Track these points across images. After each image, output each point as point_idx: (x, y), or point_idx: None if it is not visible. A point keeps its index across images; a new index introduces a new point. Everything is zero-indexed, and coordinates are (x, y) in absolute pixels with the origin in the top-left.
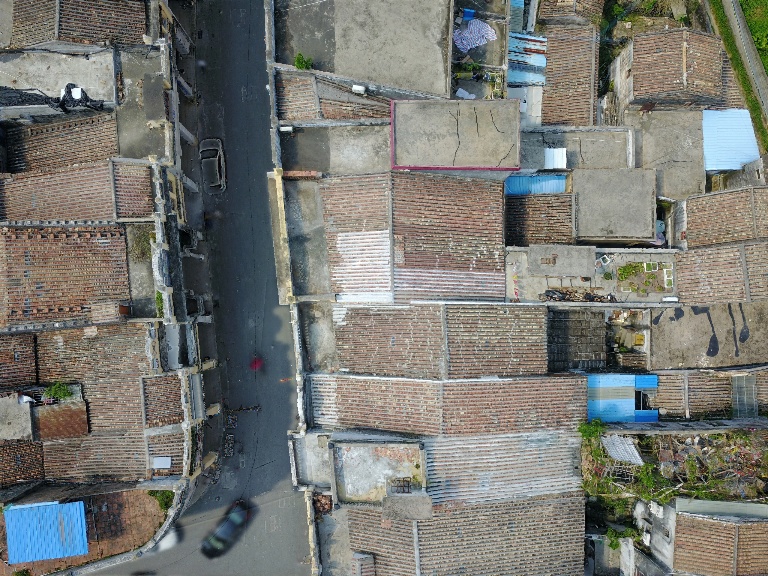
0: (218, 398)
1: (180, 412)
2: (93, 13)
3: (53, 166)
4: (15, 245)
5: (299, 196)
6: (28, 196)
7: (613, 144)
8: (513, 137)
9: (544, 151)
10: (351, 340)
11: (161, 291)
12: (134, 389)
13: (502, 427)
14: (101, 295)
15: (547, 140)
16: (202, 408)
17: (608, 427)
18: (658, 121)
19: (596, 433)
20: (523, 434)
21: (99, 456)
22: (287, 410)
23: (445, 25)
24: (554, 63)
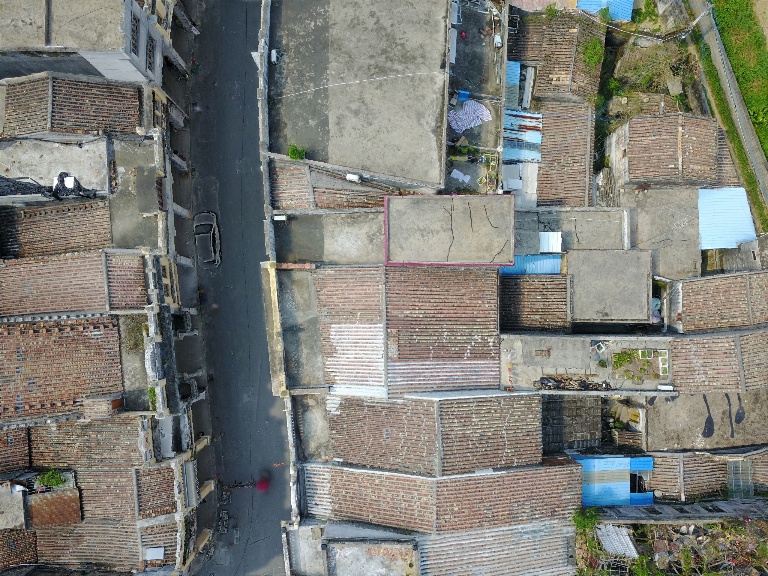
0: (212, 473)
1: (173, 501)
2: (86, 102)
3: (46, 250)
4: (7, 341)
5: (293, 286)
6: (21, 283)
7: (608, 224)
8: (507, 232)
9: (539, 235)
10: (345, 430)
11: (154, 386)
12: (127, 479)
13: (496, 521)
14: (94, 388)
15: (542, 220)
16: (195, 496)
17: (603, 515)
18: (654, 199)
19: (591, 524)
20: (517, 526)
21: (92, 544)
22: (282, 485)
23: (439, 113)
24: (549, 140)
